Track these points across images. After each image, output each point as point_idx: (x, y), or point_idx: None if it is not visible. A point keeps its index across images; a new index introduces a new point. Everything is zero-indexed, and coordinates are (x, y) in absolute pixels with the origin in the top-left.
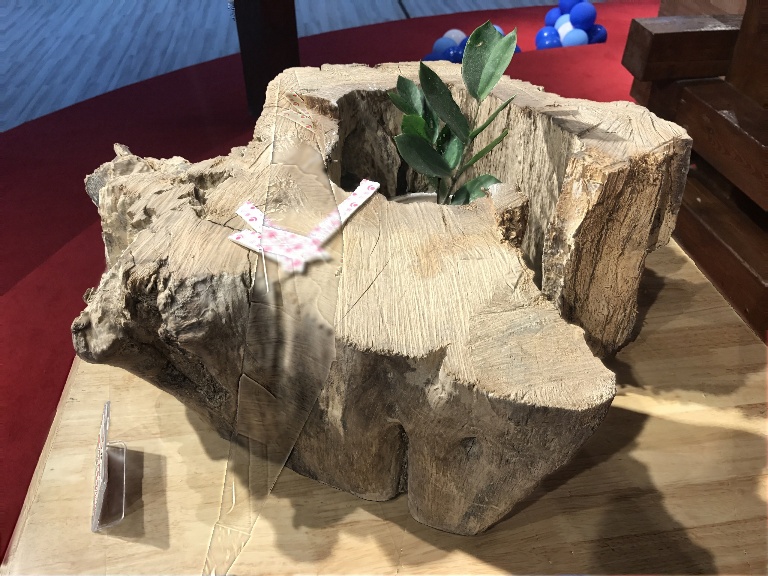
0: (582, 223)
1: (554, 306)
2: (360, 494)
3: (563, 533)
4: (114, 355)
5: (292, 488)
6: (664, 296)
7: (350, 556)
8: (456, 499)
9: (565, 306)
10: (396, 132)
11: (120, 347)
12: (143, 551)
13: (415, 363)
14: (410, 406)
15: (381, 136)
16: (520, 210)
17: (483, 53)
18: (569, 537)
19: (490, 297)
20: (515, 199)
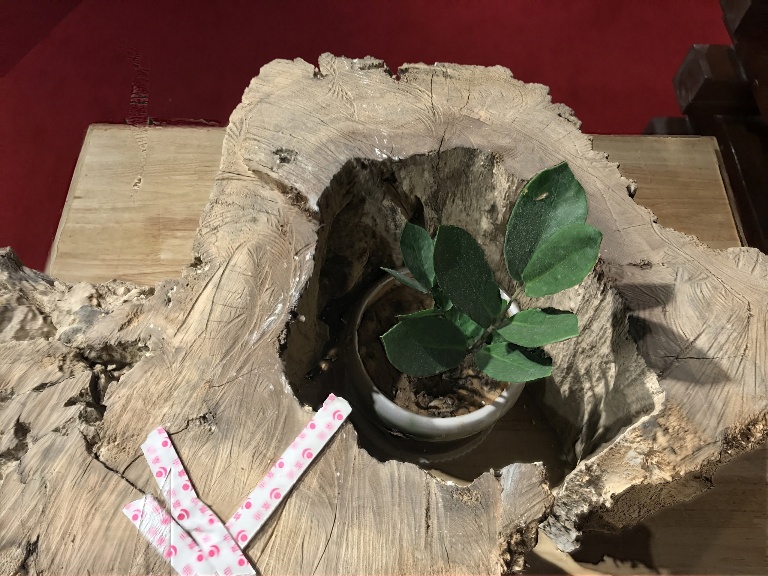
0: None
1: None
2: None
3: None
4: None
5: None
6: None
7: None
8: None
9: (584, 514)
10: (412, 190)
11: None
12: None
13: None
14: None
15: (388, 206)
16: (538, 523)
17: (545, 211)
18: None
19: None
20: (535, 503)
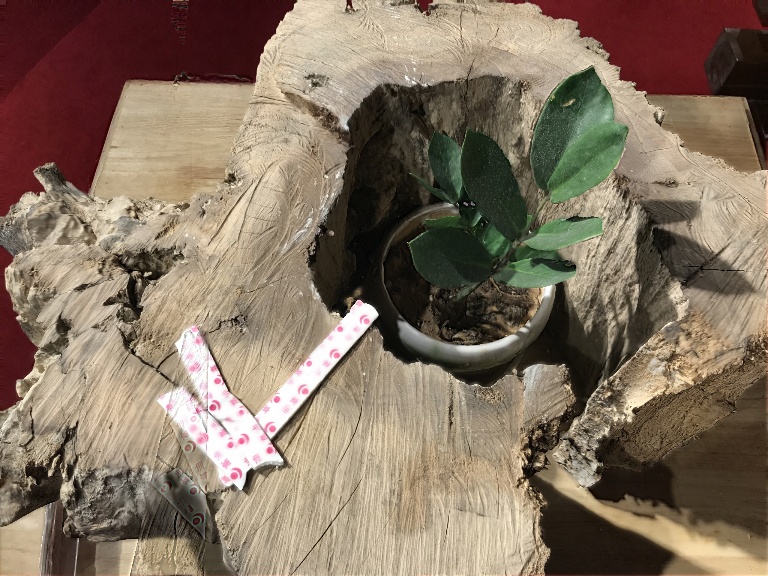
0: None
1: None
2: None
3: None
4: None
5: None
6: None
7: None
8: None
9: (605, 442)
10: (440, 125)
11: None
12: None
13: None
14: None
15: (416, 138)
16: (559, 421)
17: (571, 118)
18: None
19: None
20: (557, 402)
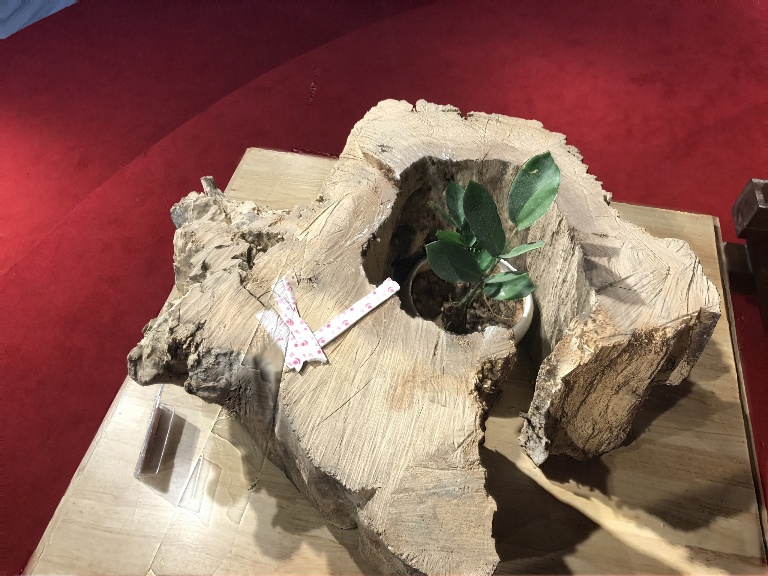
0: (574, 369)
1: (484, 475)
2: (326, 519)
3: None
4: (155, 382)
5: (282, 491)
6: (683, 405)
7: (304, 564)
8: (385, 564)
9: (550, 419)
10: None
11: (160, 378)
12: (163, 505)
13: (350, 491)
14: (349, 508)
15: None
16: (503, 361)
17: (535, 181)
18: None
19: (432, 451)
20: (503, 349)
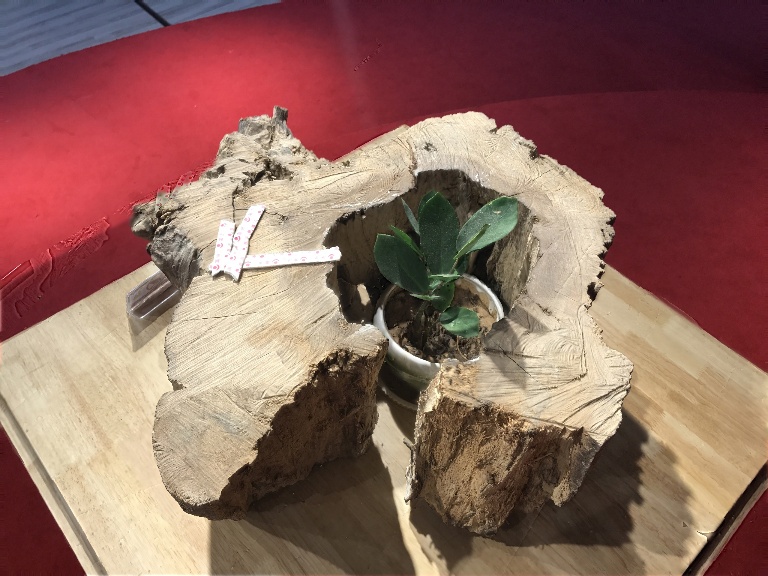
0: (435, 413)
1: (265, 432)
2: None
3: (260, 567)
4: (143, 237)
5: None
6: (599, 552)
7: None
8: None
9: (420, 457)
10: None
11: (147, 235)
12: (127, 342)
13: None
14: None
15: None
16: (358, 359)
17: (494, 221)
18: (259, 573)
19: (243, 388)
20: (366, 348)
